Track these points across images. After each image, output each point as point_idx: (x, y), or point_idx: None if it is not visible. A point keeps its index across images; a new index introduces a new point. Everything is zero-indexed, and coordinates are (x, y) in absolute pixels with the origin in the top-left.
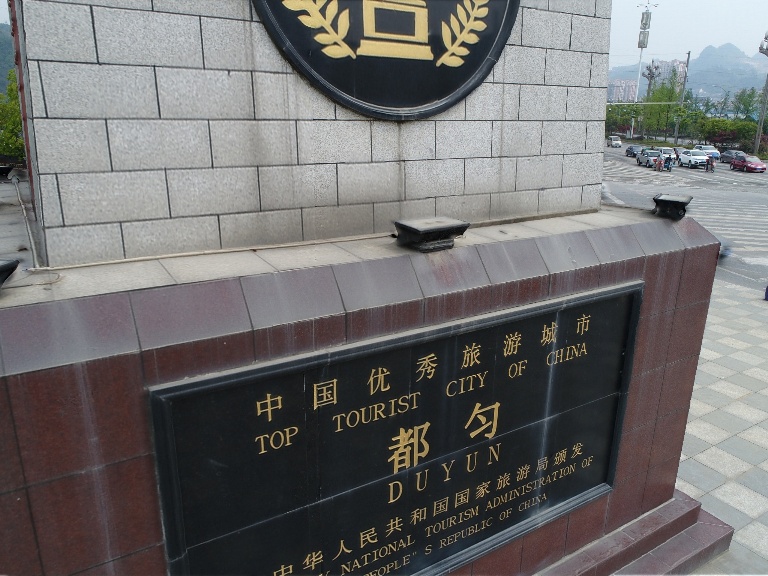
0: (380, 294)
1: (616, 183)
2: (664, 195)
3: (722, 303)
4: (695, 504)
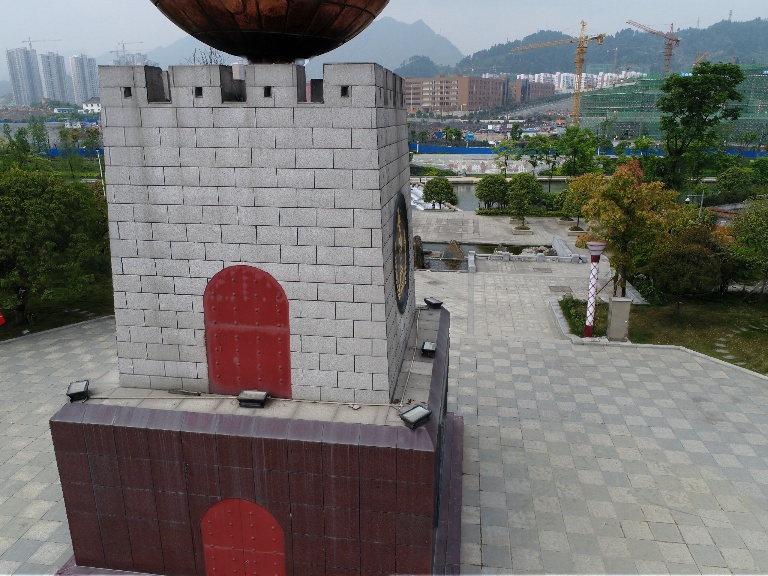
0: None
1: None
2: (83, 390)
3: None
4: (62, 568)
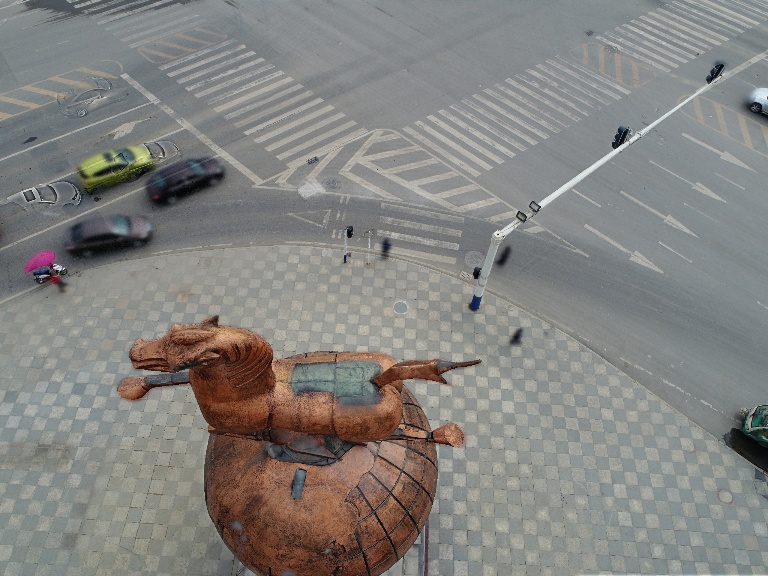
0: (422, 557)
1: (98, 22)
2: None
3: (335, 284)
4: None
